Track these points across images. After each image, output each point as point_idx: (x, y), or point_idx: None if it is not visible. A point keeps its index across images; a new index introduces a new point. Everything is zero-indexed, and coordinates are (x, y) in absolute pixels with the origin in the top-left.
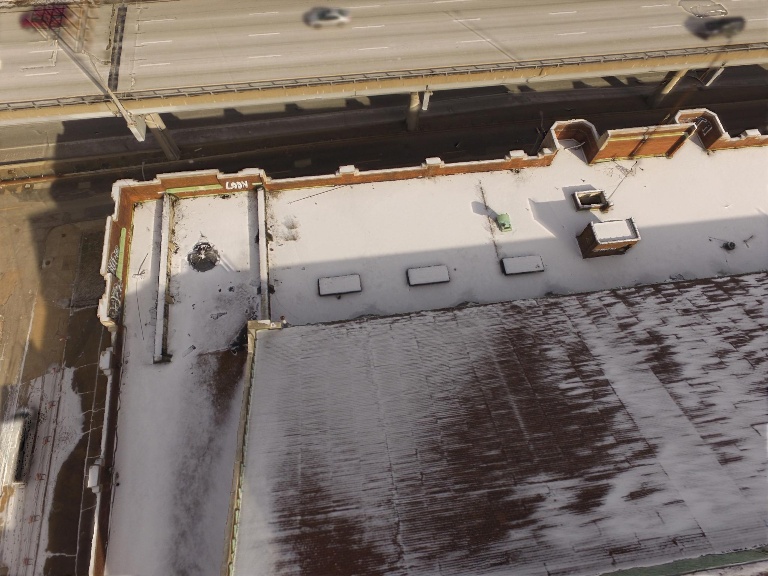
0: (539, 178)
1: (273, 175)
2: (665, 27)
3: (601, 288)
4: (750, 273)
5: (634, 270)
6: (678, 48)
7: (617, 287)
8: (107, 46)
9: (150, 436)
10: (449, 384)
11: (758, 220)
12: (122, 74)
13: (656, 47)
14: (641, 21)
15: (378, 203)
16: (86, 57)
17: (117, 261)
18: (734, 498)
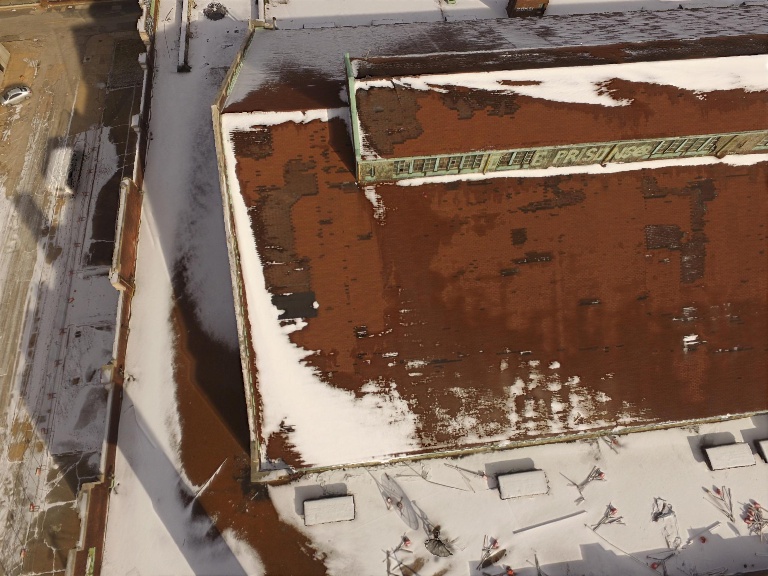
0: None
1: None
2: None
3: None
4: (629, 11)
5: None
6: None
7: None
8: None
9: (175, 113)
10: (391, 40)
11: (651, 3)
12: None
13: None
14: None
15: None
16: None
17: (150, 5)
18: None
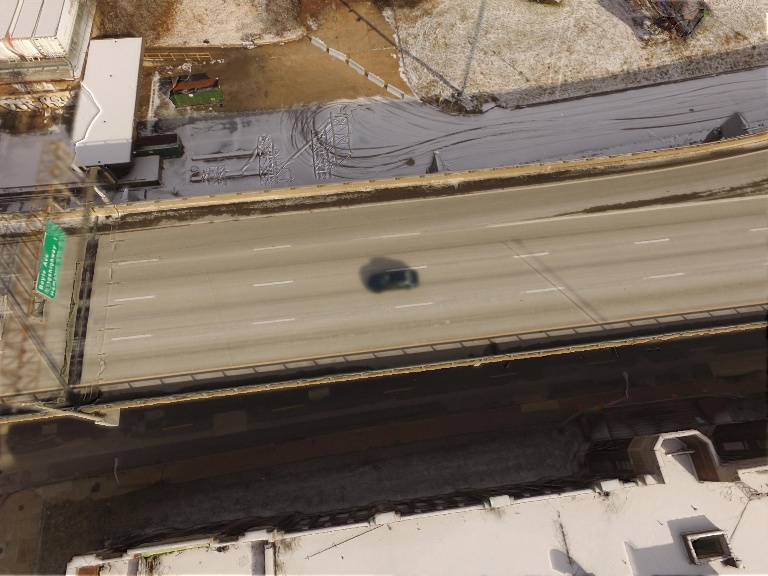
0: (636, 505)
1: (282, 412)
2: None
3: None
4: None
5: None
6: None
7: None
8: (61, 370)
9: None
10: None
11: None
12: (88, 354)
13: None
14: (752, 254)
15: (425, 555)
16: (43, 324)
17: None
18: None
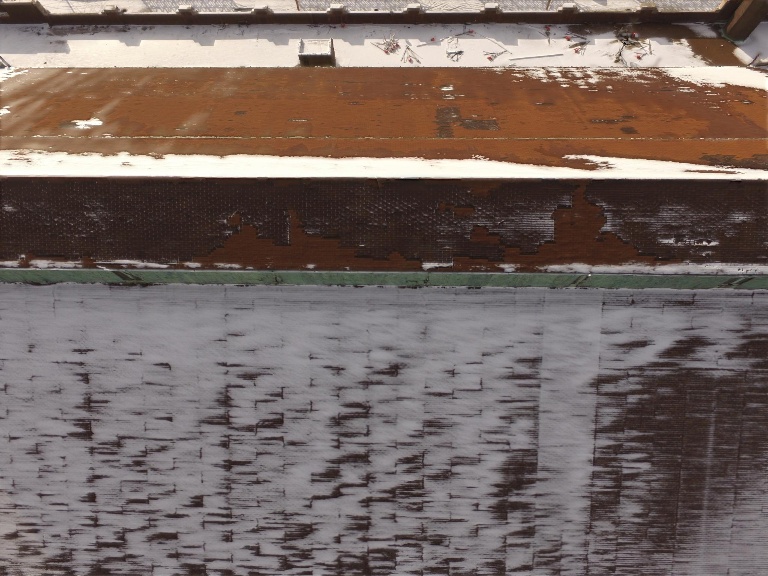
0: None
1: None
2: None
3: None
4: None
5: None
6: None
7: None
8: None
9: None
10: None
11: None
12: None
13: None
14: None
15: None
16: None
17: None
18: (554, 328)
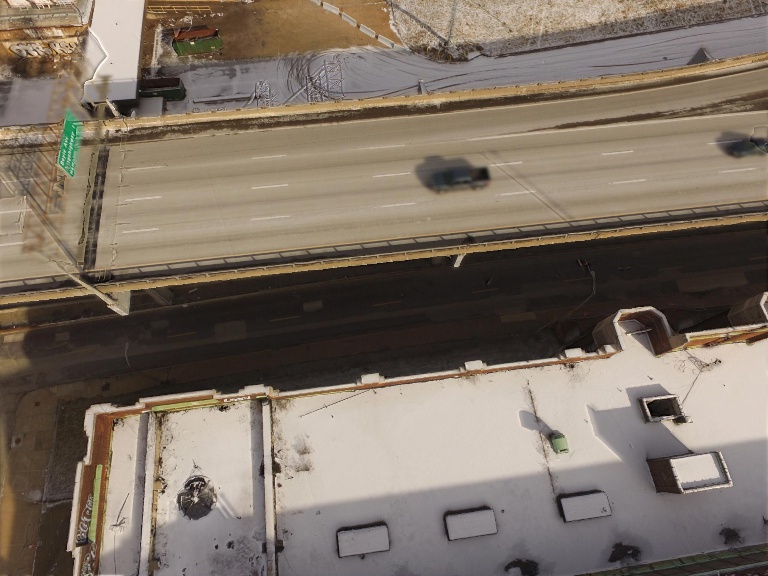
0: (598, 375)
1: (279, 322)
2: (737, 171)
3: (681, 536)
4: None
5: (719, 508)
6: (754, 200)
7: (712, 570)
8: (79, 240)
9: None
10: None
11: None
12: (101, 244)
13: (729, 199)
14: (709, 163)
15: (407, 414)
16: (59, 220)
17: (90, 516)
18: None
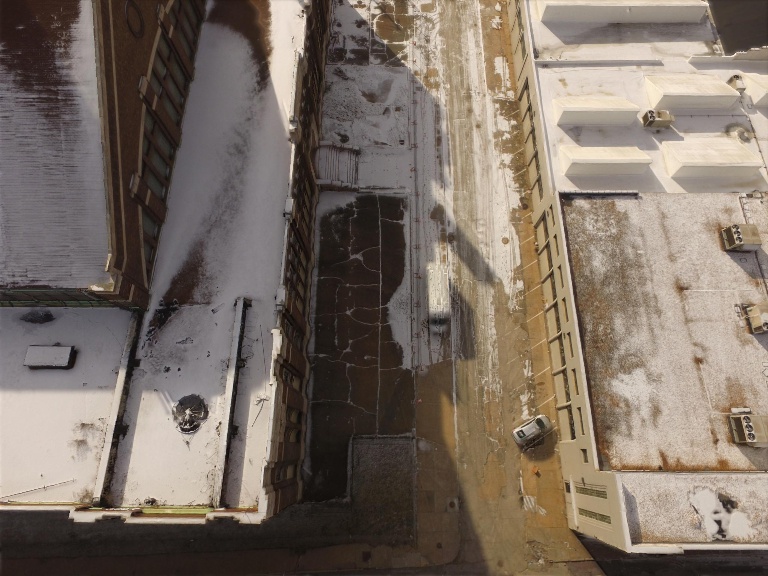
0: None
1: None
2: None
3: None
4: None
5: None
6: None
7: None
8: None
9: (258, 240)
10: None
11: None
12: None
13: None
14: None
15: None
16: None
17: None
18: None
